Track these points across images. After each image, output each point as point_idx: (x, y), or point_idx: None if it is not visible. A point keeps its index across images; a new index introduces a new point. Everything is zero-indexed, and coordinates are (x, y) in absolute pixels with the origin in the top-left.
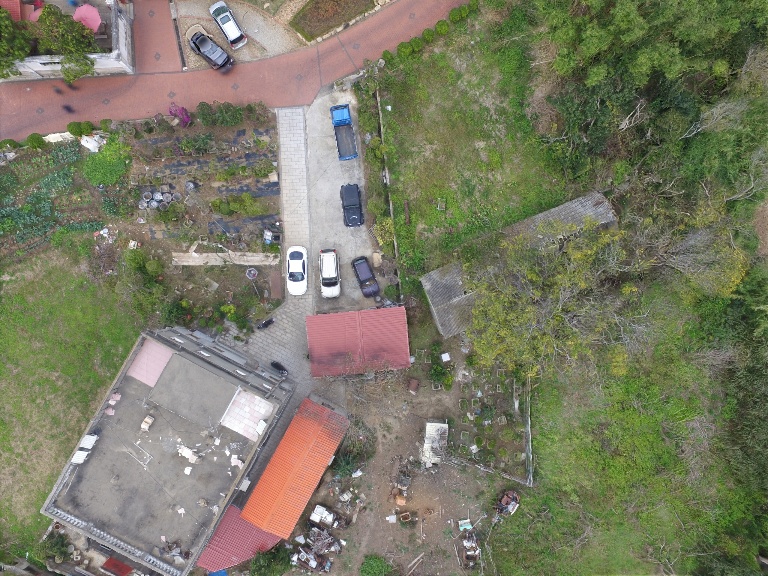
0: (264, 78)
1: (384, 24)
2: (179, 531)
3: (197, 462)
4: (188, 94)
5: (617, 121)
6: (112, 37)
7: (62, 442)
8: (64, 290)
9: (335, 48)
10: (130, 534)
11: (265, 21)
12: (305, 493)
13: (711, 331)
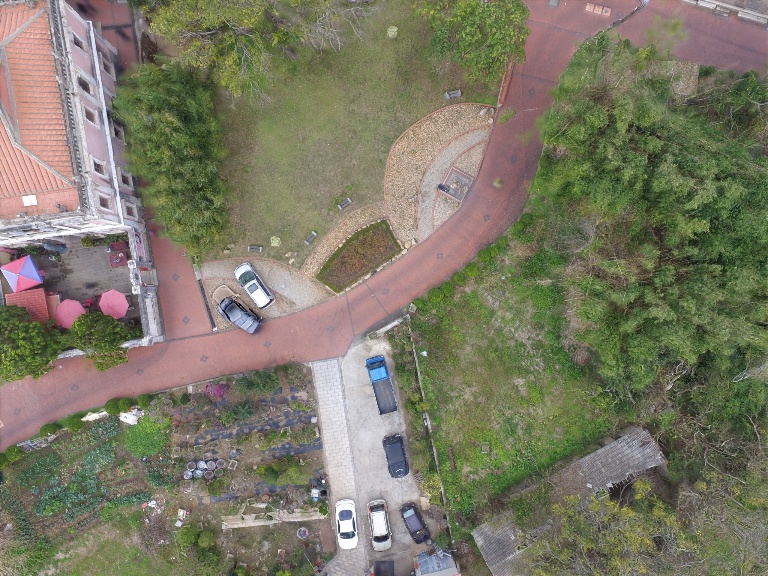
0: (296, 333)
1: (412, 266)
2: None
3: None
4: (221, 356)
5: (663, 382)
6: (142, 323)
7: None
8: (119, 563)
9: (364, 295)
10: None
11: (291, 276)
12: None
13: (765, 554)
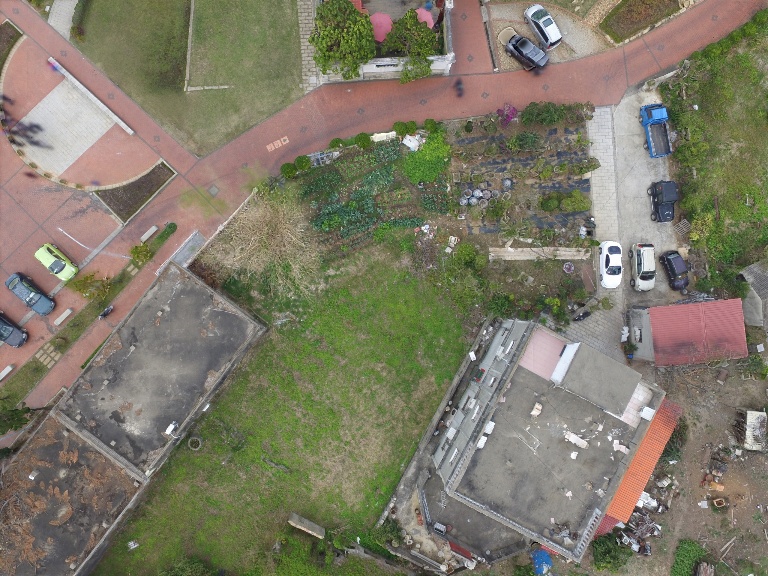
0: (573, 79)
1: (688, 26)
2: (567, 513)
3: (587, 447)
4: (501, 94)
5: None
6: (447, 40)
7: (388, 431)
8: (387, 284)
9: (640, 49)
10: (522, 516)
11: (574, 24)
12: (643, 479)
13: None
